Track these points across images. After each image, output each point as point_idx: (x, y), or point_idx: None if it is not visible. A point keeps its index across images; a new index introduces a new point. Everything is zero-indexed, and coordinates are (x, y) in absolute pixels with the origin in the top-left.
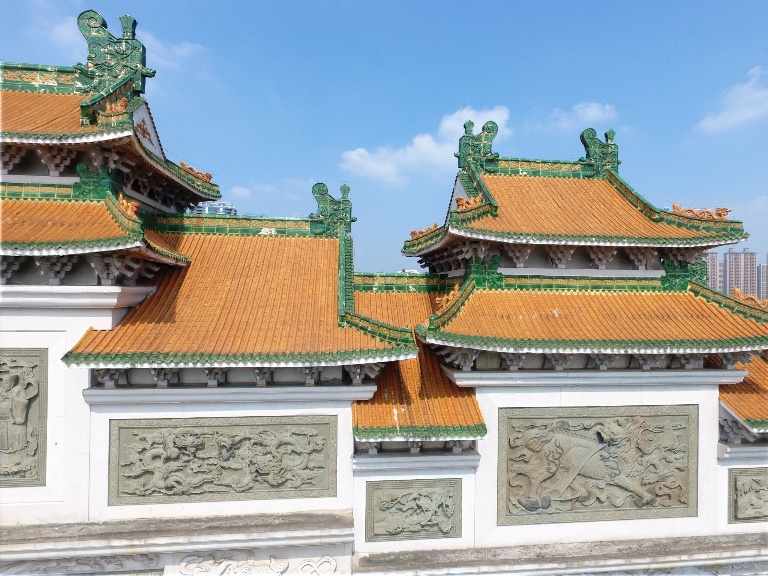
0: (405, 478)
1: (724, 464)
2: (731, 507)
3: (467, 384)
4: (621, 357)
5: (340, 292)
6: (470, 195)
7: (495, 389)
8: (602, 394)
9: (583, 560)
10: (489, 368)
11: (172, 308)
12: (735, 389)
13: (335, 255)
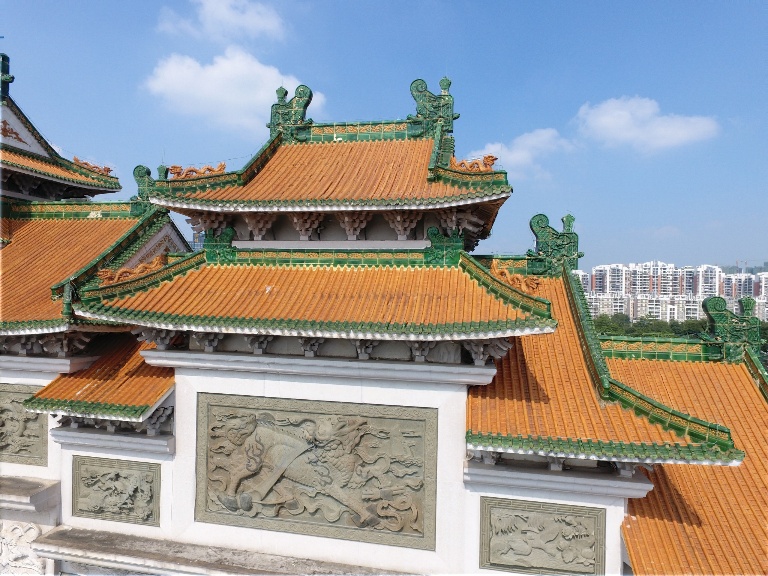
0: (107, 456)
1: (475, 489)
2: (485, 547)
3: (157, 363)
4: (351, 344)
5: (82, 268)
6: None
7: (194, 371)
8: (313, 386)
9: (256, 575)
10: (202, 349)
11: None
12: (501, 393)
13: None
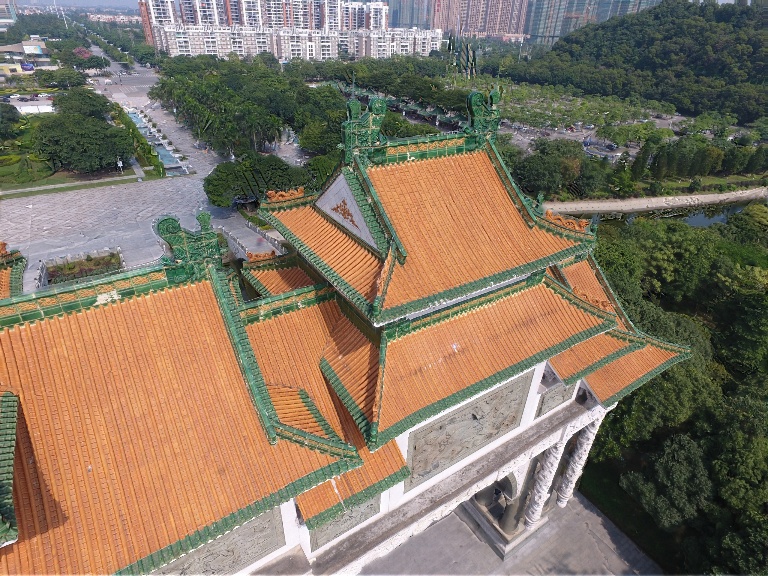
0: None
1: None
2: (537, 412)
3: None
4: None
5: (255, 395)
6: (368, 221)
7: None
8: None
9: (459, 493)
10: None
11: (45, 495)
12: None
13: (216, 314)
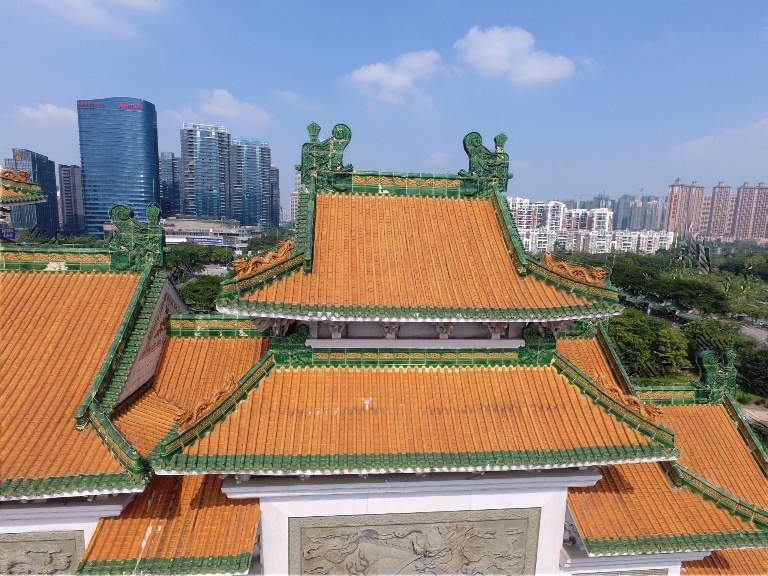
0: None
1: (567, 569)
2: None
3: (242, 497)
4: None
5: (98, 373)
6: None
7: (284, 497)
8: (420, 499)
9: None
10: None
11: None
12: None
13: None
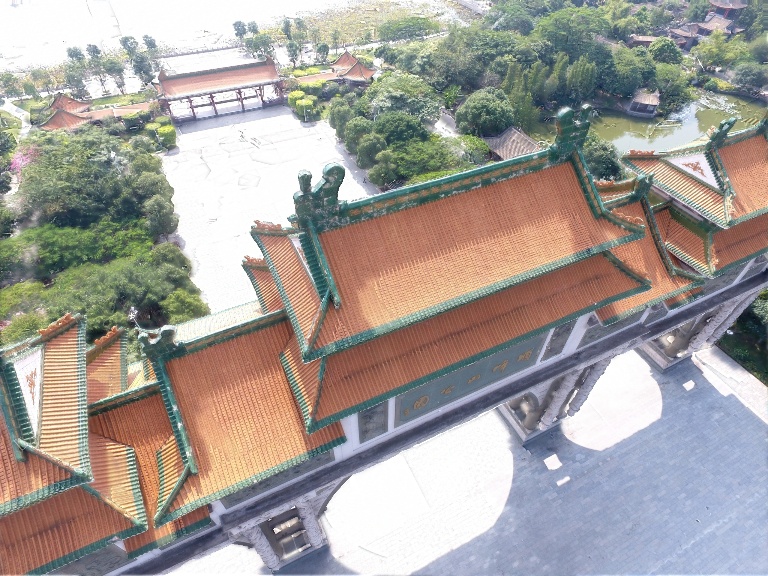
0: None
1: None
2: None
3: None
4: None
5: None
6: (31, 351)
7: None
8: None
9: None
10: None
11: None
12: None
13: None
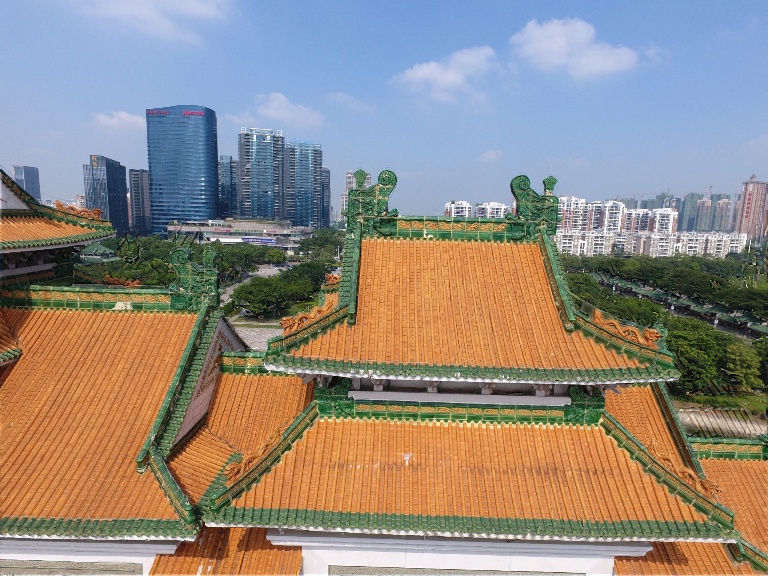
0: None
1: None
2: None
3: None
4: None
5: (157, 416)
6: None
7: (325, 546)
8: (459, 557)
9: None
10: None
11: None
12: None
13: None
